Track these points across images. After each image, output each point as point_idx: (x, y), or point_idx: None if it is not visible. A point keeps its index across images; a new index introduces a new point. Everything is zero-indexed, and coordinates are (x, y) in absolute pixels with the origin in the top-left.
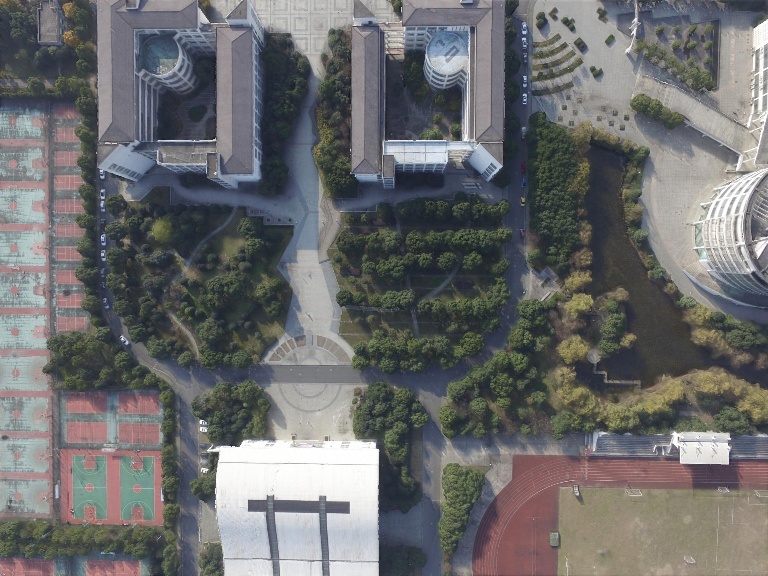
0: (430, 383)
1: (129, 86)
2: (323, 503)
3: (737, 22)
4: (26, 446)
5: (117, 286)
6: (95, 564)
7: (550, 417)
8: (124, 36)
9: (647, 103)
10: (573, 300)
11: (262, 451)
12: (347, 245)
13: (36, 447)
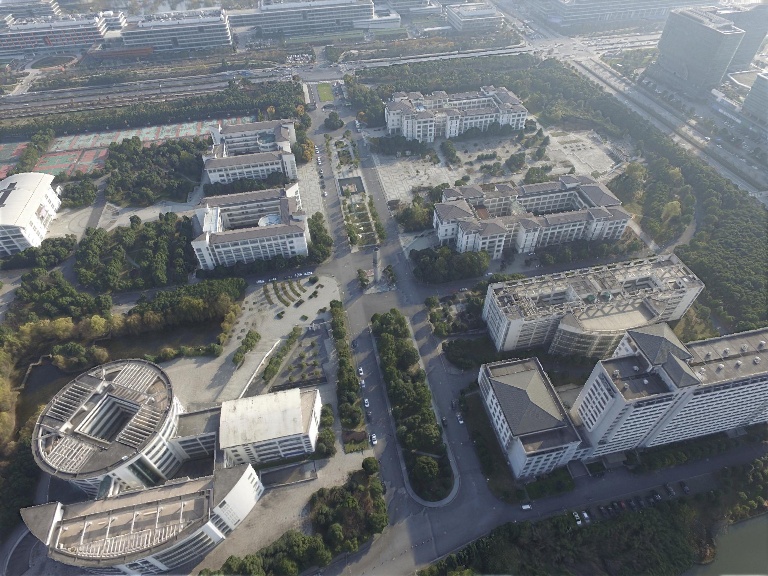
0: (68, 270)
1: (247, 130)
2: (0, 206)
3: (328, 396)
4: (89, 142)
5: (160, 150)
6: (14, 167)
7: (15, 331)
8: (270, 125)
9: (250, 336)
10: (102, 318)
11: (45, 187)
12: (166, 215)
13: (87, 144)
